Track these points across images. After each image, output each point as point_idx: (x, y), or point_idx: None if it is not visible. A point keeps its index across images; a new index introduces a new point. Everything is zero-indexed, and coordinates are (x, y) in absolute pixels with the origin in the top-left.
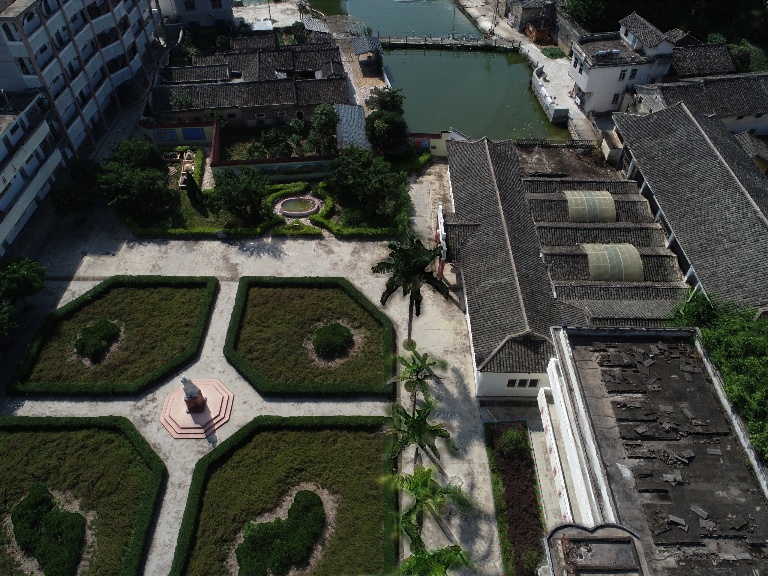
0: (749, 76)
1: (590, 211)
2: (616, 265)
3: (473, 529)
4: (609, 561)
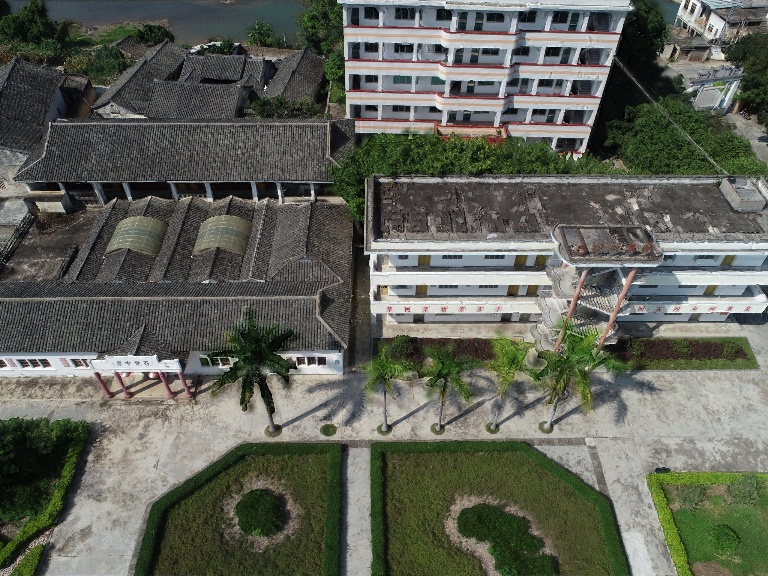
0: (3, 85)
1: (151, 236)
2: (235, 233)
3: (471, 387)
4: (577, 239)
